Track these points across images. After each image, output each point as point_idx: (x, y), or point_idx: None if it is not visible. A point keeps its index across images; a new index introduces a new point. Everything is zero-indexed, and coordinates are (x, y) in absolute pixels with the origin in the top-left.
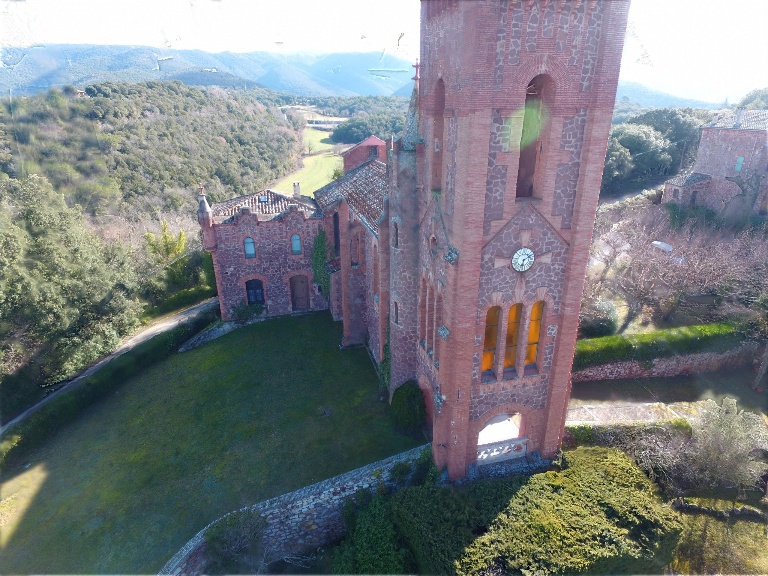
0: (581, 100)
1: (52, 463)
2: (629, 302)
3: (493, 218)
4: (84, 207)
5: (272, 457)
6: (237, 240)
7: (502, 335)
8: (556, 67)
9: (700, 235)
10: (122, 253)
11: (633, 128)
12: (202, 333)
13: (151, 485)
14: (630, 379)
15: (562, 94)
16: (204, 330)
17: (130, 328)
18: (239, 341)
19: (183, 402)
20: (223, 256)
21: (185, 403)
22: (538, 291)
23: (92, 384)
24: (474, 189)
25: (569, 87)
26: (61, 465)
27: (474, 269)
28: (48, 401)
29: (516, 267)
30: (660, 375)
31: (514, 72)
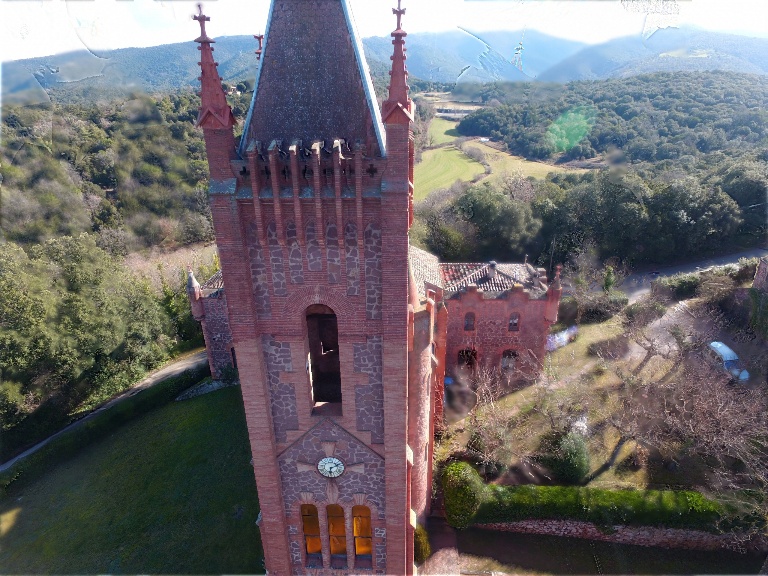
0: (371, 327)
1: (35, 501)
2: (637, 427)
3: (288, 428)
4: (175, 225)
5: (172, 552)
6: (222, 311)
7: (321, 529)
8: (332, 297)
9: (759, 354)
10: (148, 302)
11: (757, 169)
12: (196, 386)
13: (78, 552)
14: (584, 540)
15: (346, 322)
16: (198, 384)
17: (158, 362)
18: (217, 404)
19: (146, 463)
20: (211, 324)
21: (146, 465)
22: (355, 496)
23: (90, 428)
24: (253, 407)
25: (353, 315)
26: (38, 506)
27: (269, 474)
28: (56, 438)
29: (324, 473)
30: (628, 542)
31: (283, 302)
